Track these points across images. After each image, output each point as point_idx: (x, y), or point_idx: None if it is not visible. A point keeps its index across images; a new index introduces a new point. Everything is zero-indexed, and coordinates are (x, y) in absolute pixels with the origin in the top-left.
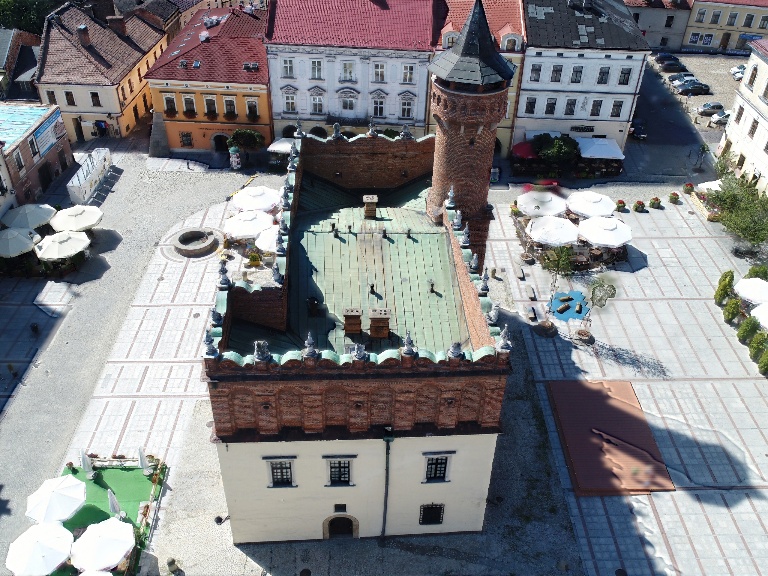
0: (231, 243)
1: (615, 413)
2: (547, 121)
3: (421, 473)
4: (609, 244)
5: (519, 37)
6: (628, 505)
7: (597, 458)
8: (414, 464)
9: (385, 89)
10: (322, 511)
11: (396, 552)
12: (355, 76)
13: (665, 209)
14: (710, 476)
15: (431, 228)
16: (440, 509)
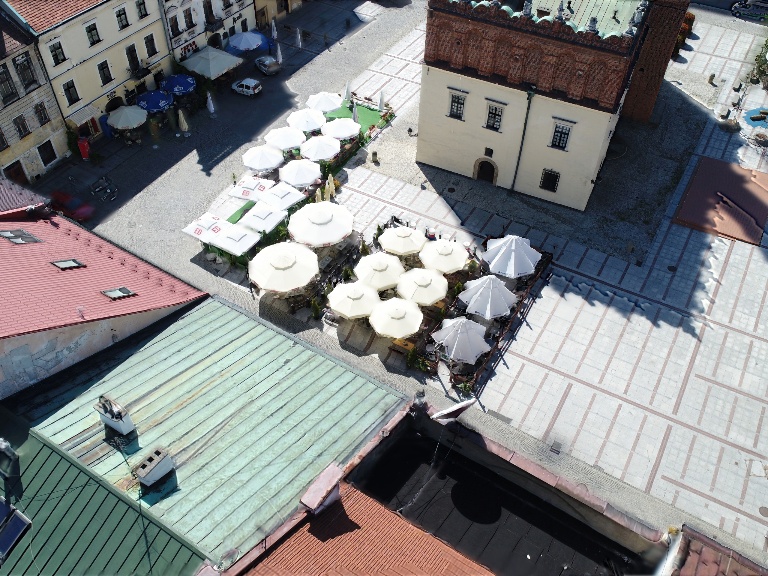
0: None
1: (747, 190)
2: None
3: (549, 136)
4: None
5: None
6: (710, 240)
7: (707, 208)
8: (545, 126)
9: None
10: (476, 151)
11: (516, 201)
12: None
13: None
14: None
15: None
16: (557, 177)
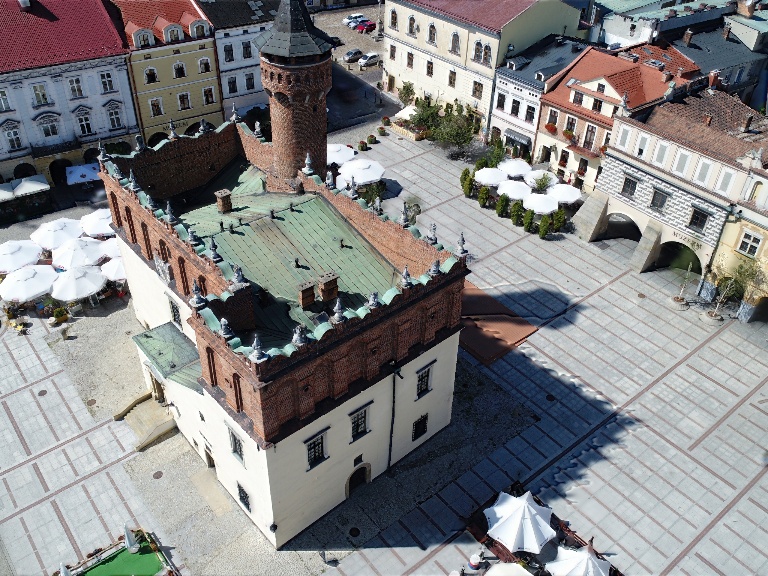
0: (15, 311)
1: (466, 299)
2: (250, 96)
3: (414, 392)
4: (373, 180)
5: (205, 22)
6: (520, 354)
7: (480, 334)
8: (410, 387)
9: (87, 104)
10: (346, 471)
11: (406, 474)
12: (50, 98)
13: (381, 142)
14: (549, 310)
15: (298, 198)
16: (425, 419)
